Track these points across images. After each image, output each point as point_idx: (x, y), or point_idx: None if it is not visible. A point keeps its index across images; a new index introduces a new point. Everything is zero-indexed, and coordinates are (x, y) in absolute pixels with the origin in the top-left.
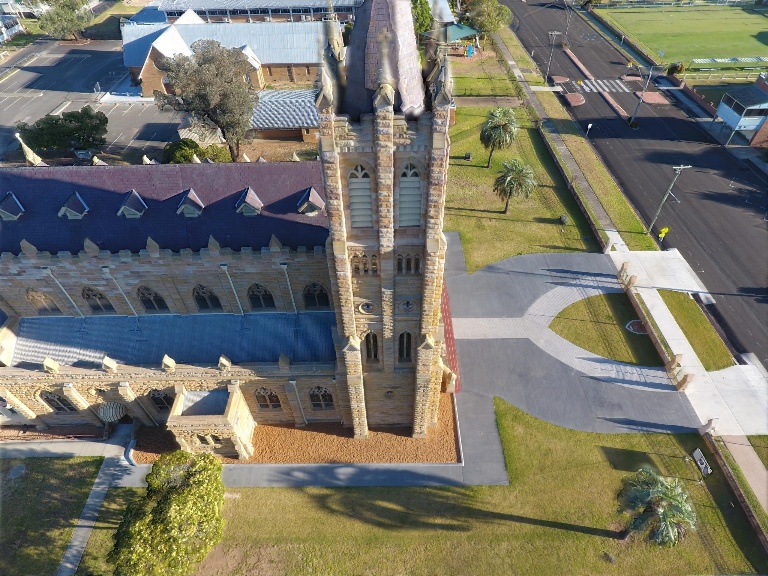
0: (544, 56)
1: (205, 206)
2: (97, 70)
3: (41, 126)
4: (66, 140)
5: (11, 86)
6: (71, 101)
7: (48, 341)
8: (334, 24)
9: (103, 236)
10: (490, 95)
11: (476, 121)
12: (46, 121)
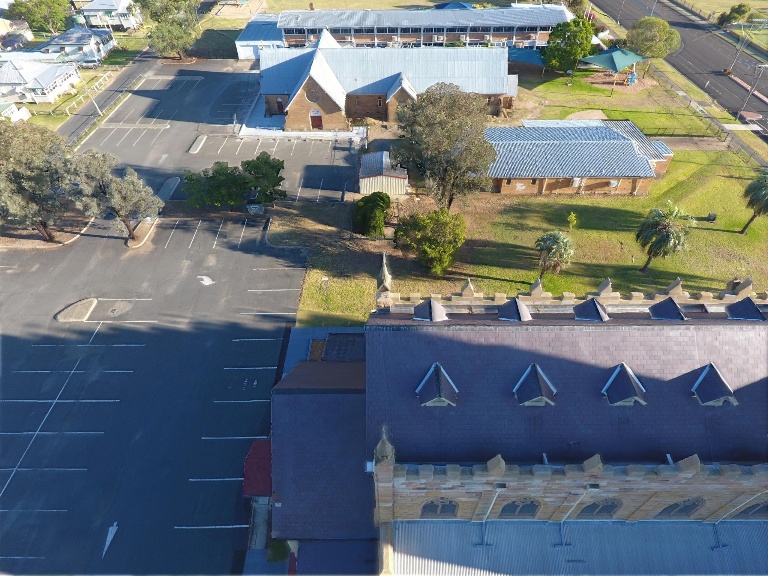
0: (713, 86)
1: (733, 390)
2: (218, 96)
3: (209, 175)
4: (240, 193)
5: (130, 115)
6: (207, 135)
7: (439, 559)
8: (502, 50)
9: (578, 432)
10: (685, 135)
11: (689, 169)
12: (222, 172)
